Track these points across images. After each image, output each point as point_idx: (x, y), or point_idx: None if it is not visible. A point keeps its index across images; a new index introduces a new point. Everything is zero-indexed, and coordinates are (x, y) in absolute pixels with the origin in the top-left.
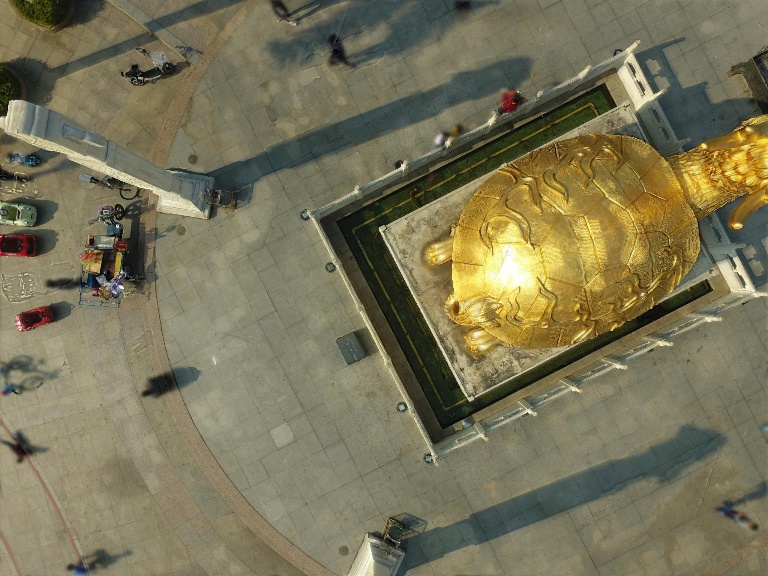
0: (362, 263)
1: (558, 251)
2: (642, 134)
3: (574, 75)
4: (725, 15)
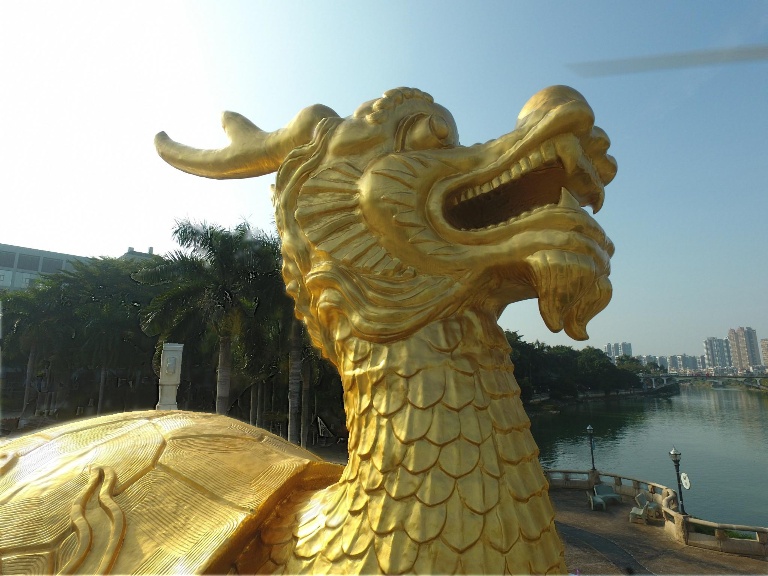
0: None
1: None
2: None
3: None
4: None
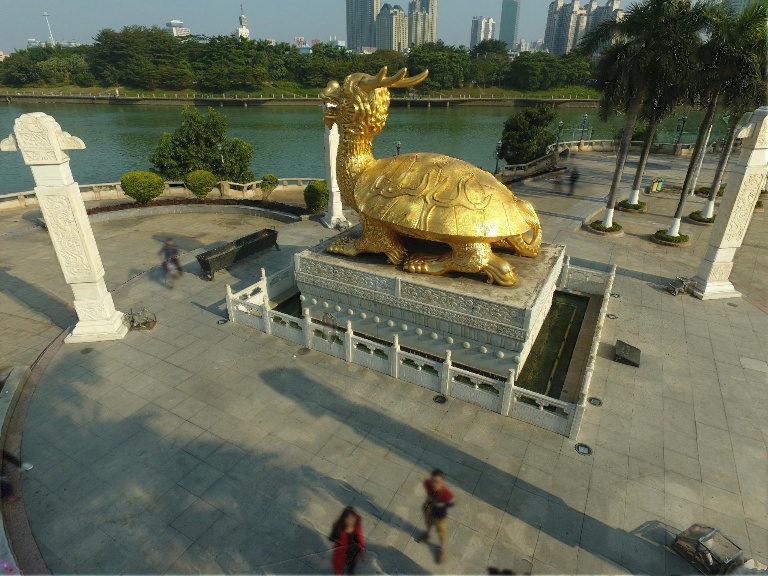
0: (556, 394)
1: (464, 166)
2: (315, 246)
3: (256, 335)
4: (163, 294)
